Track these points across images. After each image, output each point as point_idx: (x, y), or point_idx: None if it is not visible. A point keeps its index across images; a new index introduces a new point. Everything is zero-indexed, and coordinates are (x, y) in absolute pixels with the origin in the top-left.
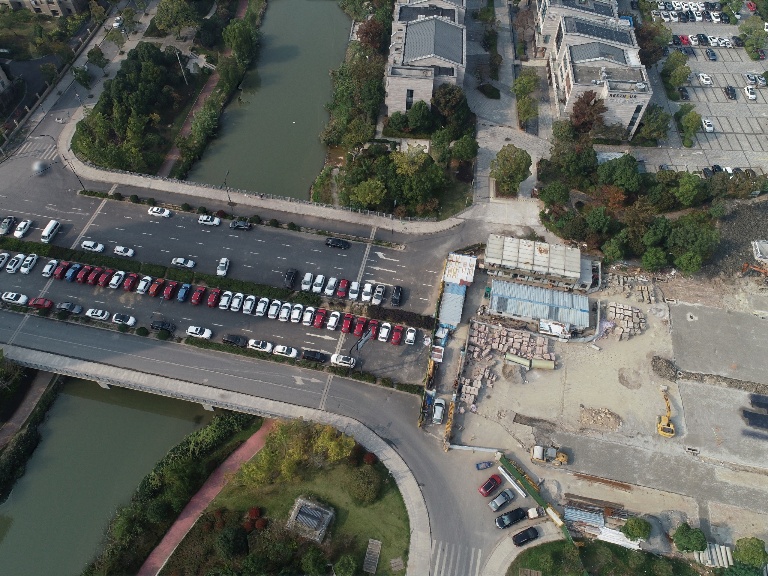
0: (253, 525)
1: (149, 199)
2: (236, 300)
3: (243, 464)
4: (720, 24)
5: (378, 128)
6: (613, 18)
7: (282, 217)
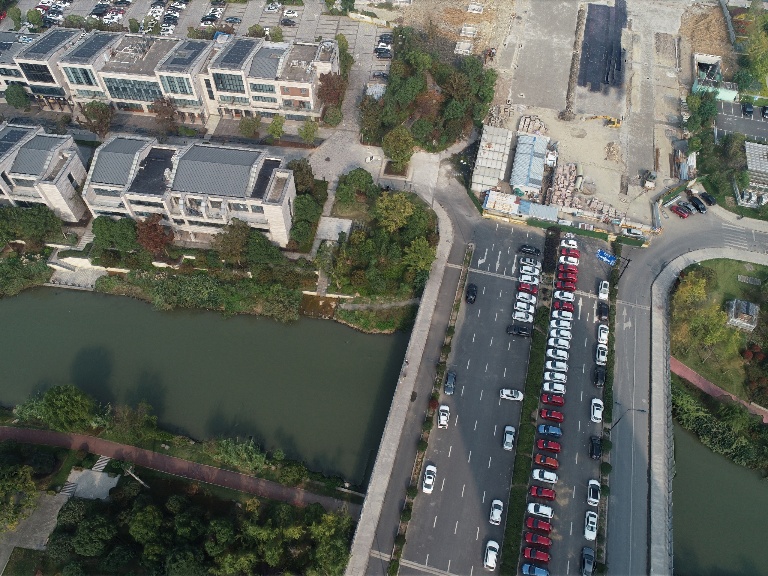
0: (759, 353)
1: (412, 491)
2: (557, 375)
3: (735, 344)
4: (187, 6)
5: (294, 257)
6: (213, 43)
7: (434, 344)
